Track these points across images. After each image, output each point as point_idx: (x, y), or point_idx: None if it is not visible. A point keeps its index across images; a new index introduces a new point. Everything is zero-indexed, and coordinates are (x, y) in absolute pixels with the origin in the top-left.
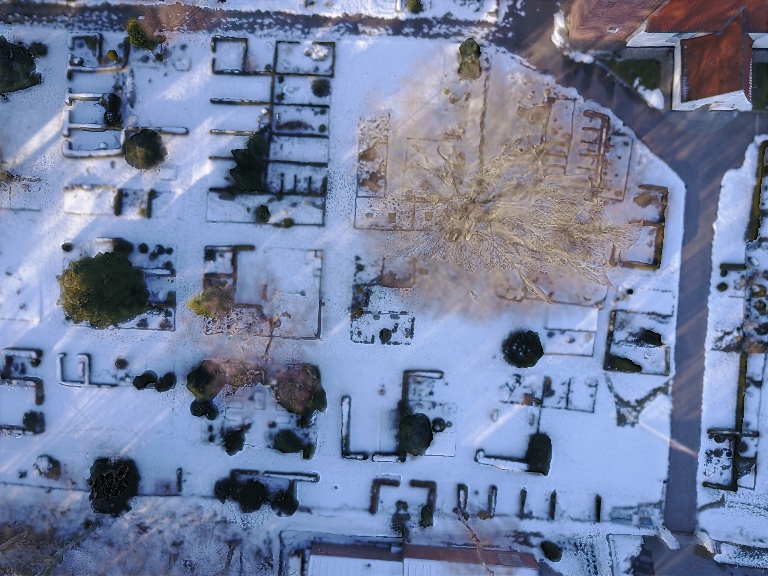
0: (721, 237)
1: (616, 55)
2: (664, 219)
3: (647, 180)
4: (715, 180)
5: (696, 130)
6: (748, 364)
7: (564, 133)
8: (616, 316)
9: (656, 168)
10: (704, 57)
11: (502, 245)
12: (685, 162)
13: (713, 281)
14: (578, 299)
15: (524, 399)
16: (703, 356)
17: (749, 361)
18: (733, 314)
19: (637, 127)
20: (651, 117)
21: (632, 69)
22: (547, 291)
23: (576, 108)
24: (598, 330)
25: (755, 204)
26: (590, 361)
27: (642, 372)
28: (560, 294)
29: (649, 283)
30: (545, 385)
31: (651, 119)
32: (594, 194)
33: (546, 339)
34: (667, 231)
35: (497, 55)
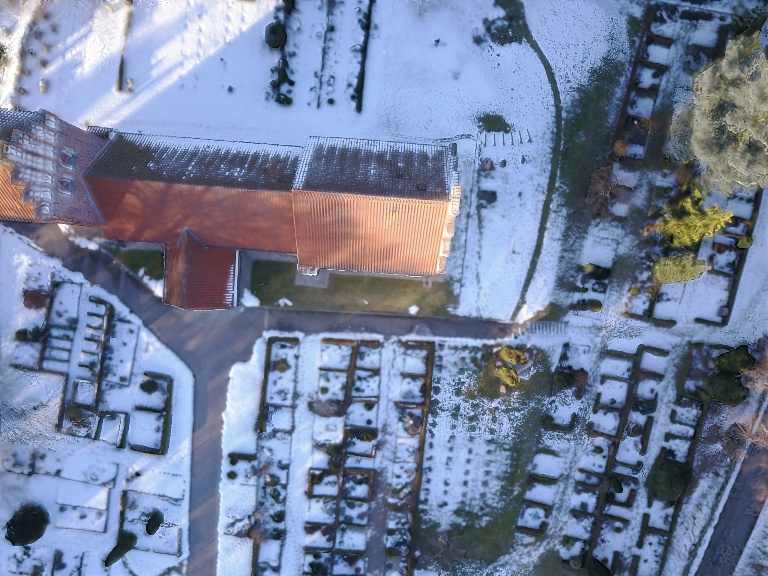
0: (231, 426)
1: (121, 244)
2: (167, 408)
3: (154, 367)
4: (223, 371)
5: (202, 322)
6: (264, 549)
7: (69, 316)
8: (129, 495)
9: (163, 356)
10: (173, 264)
11: (9, 420)
12: (192, 352)
13: (224, 468)
14: (86, 478)
15: (33, 571)
16: (216, 540)
17: (265, 546)
18: (245, 501)
19: (144, 315)
20: (158, 306)
21: (137, 258)
22: (55, 468)
23: (83, 292)
24: (112, 507)
25: (261, 398)
26: (105, 536)
27: (155, 551)
28: (69, 471)
29: (160, 466)
30: (56, 558)
31: (158, 308)
32: (96, 379)
33: (58, 513)
34: (177, 417)
35: (3, 235)
